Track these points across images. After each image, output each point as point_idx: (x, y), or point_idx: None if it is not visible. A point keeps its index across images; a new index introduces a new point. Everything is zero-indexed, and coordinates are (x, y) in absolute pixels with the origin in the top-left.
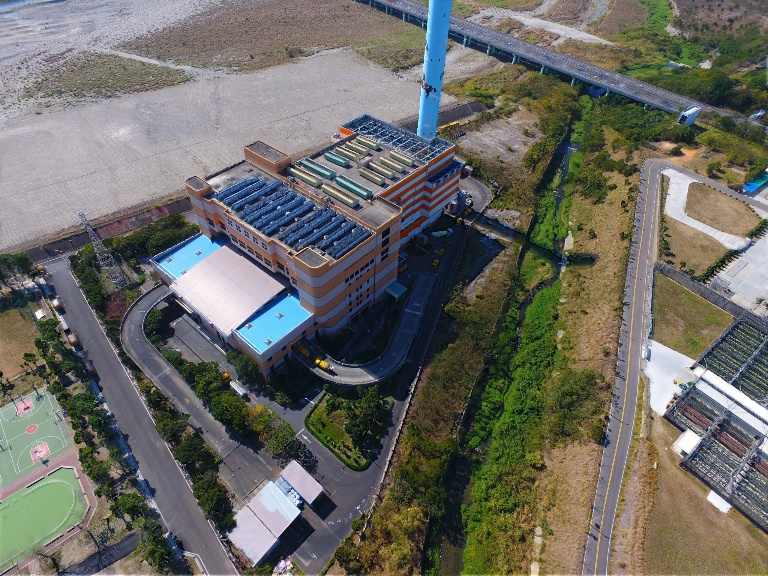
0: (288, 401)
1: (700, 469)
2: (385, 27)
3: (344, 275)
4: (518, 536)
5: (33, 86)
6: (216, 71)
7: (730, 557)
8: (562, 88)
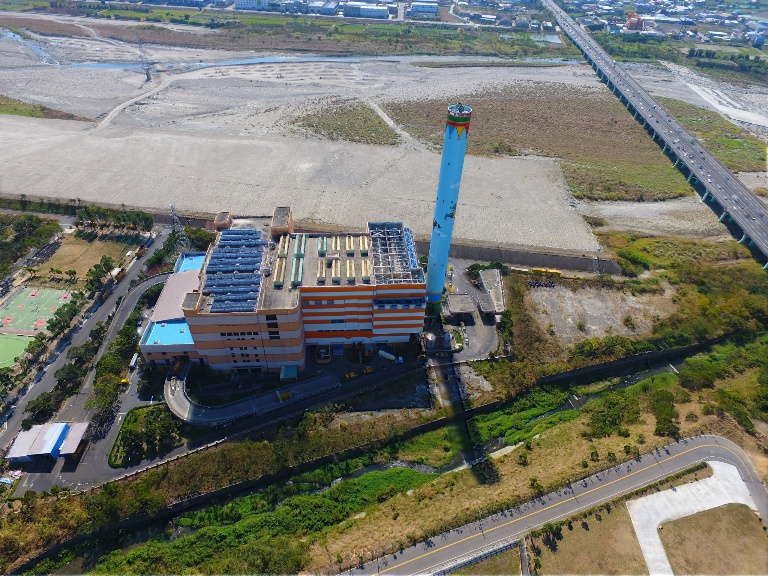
0: (139, 389)
1: None
2: (630, 152)
3: (219, 329)
4: None
5: (303, 117)
6: (422, 144)
7: None
8: (751, 296)
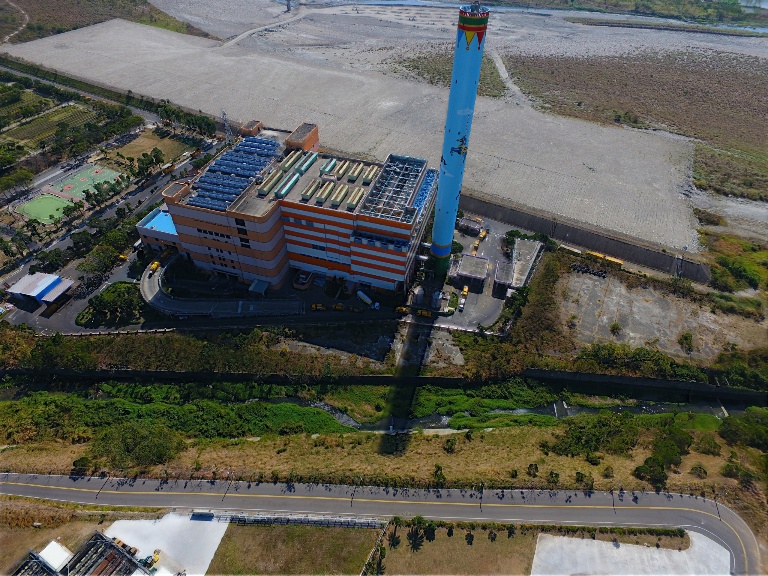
0: (129, 266)
1: (22, 571)
2: None
3: (195, 223)
4: None
5: (413, 58)
6: (529, 100)
7: None
8: None
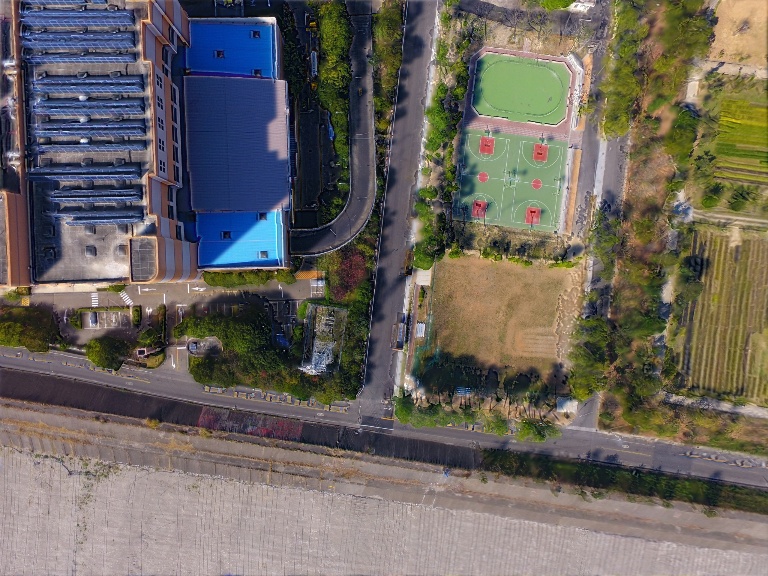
0: (286, 7)
1: None
2: None
3: None
4: None
5: None
6: None
7: None
8: None
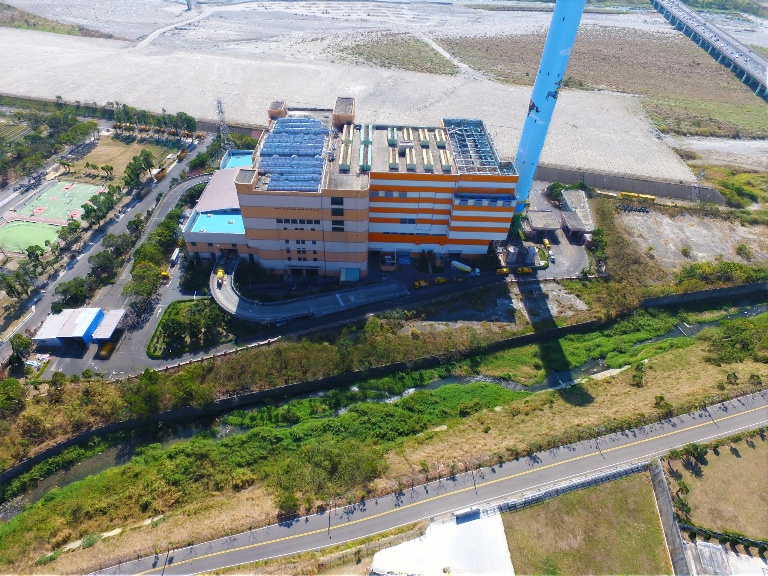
0: (181, 282)
1: None
2: (718, 92)
3: (275, 213)
4: (142, 501)
5: (352, 46)
6: (483, 75)
7: None
8: None
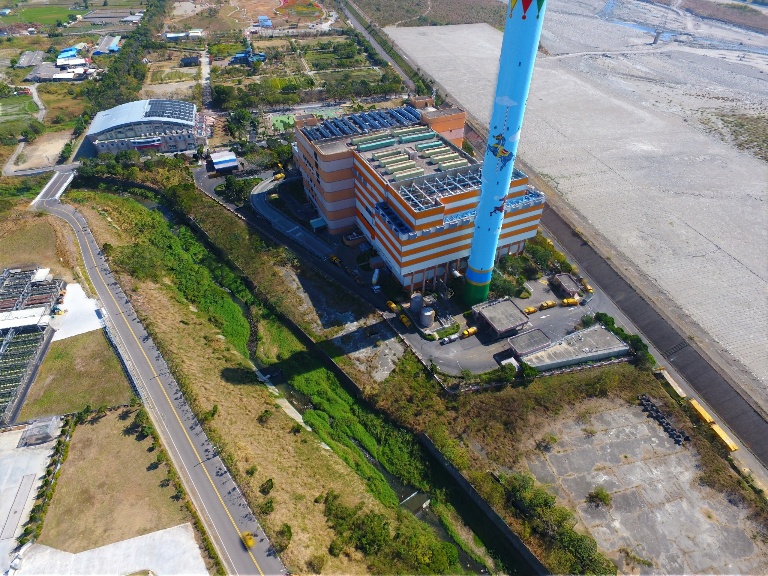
0: None
1: None
2: None
3: None
4: None
5: (750, 116)
6: None
7: (2, 257)
8: None
